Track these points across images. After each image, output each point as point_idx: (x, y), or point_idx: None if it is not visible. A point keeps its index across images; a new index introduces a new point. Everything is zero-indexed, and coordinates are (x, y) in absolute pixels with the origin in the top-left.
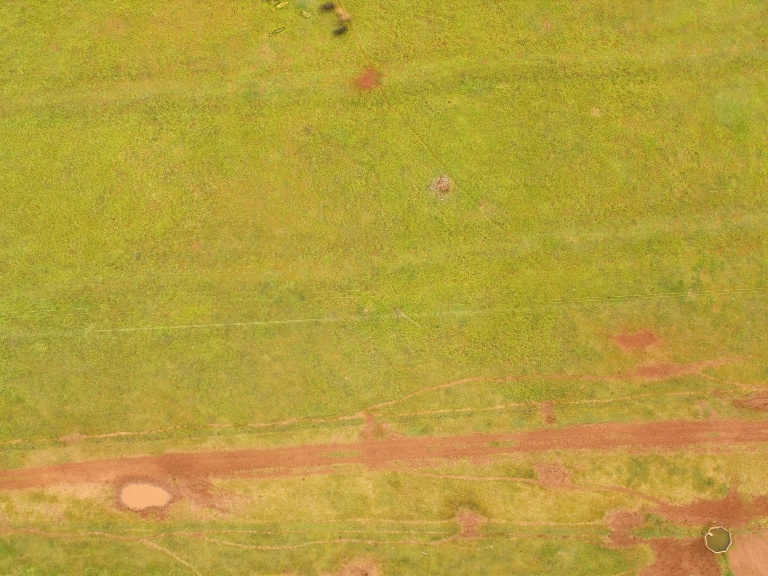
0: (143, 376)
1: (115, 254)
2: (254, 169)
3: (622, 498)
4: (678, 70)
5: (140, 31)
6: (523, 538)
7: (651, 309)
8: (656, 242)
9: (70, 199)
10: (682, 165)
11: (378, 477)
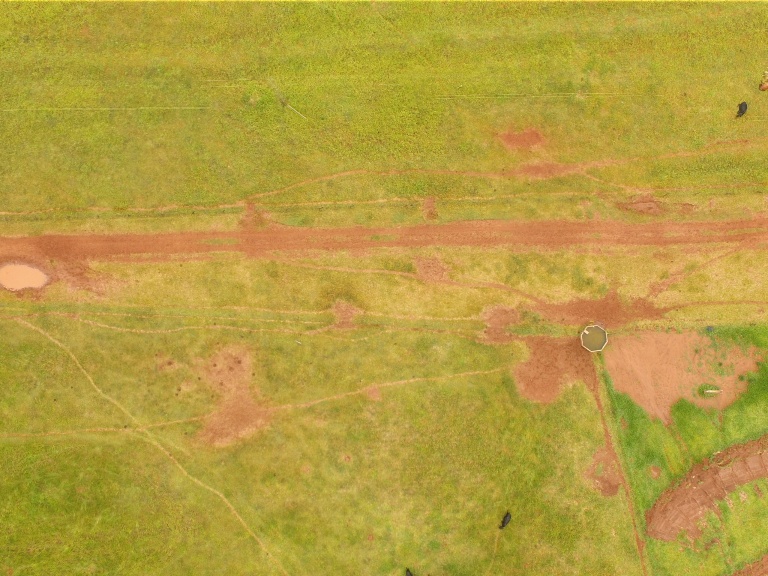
0: (25, 157)
1: (3, 35)
2: None
3: (500, 295)
4: None
5: None
6: (398, 331)
7: (538, 108)
8: (547, 43)
9: None
10: None
11: (256, 266)
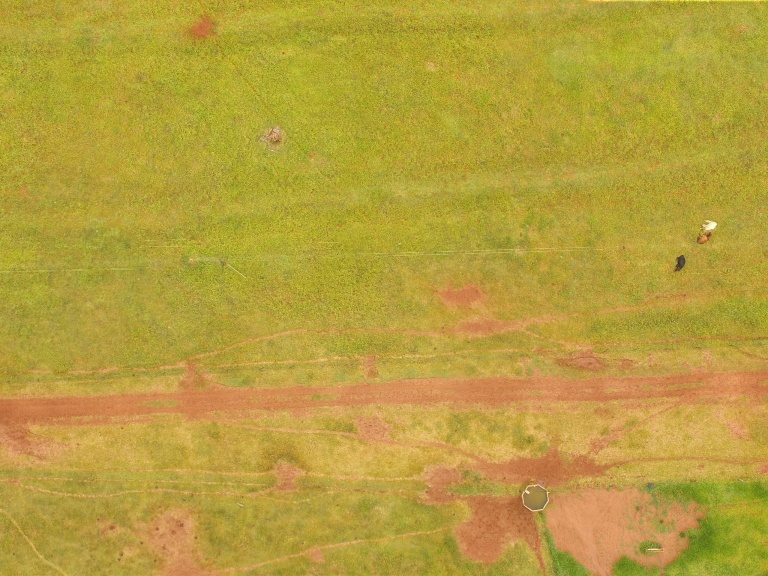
0: None
1: None
2: (84, 116)
3: (441, 454)
4: (515, 26)
5: None
6: (340, 492)
7: (477, 265)
8: (485, 198)
9: None
10: (515, 122)
11: (197, 427)
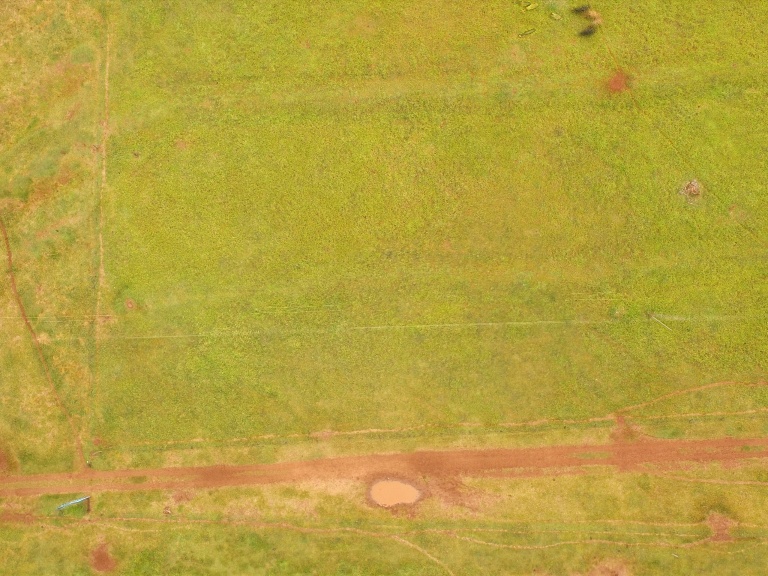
0: (394, 374)
1: (367, 252)
2: (504, 170)
3: None
4: None
5: (390, 30)
6: None
7: None
8: None
9: (322, 196)
10: None
11: (628, 479)
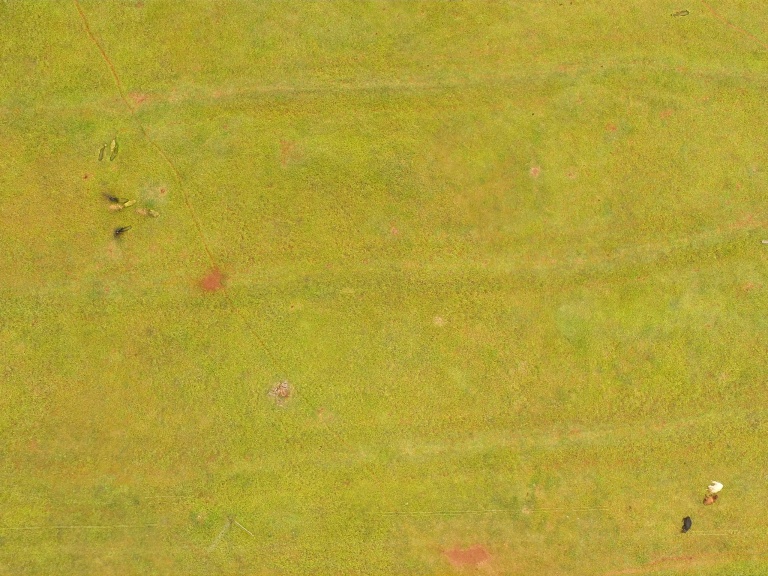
0: None
1: None
2: (94, 369)
3: None
4: (522, 281)
5: None
6: None
7: (484, 525)
8: (492, 457)
9: None
10: (522, 378)
11: None
